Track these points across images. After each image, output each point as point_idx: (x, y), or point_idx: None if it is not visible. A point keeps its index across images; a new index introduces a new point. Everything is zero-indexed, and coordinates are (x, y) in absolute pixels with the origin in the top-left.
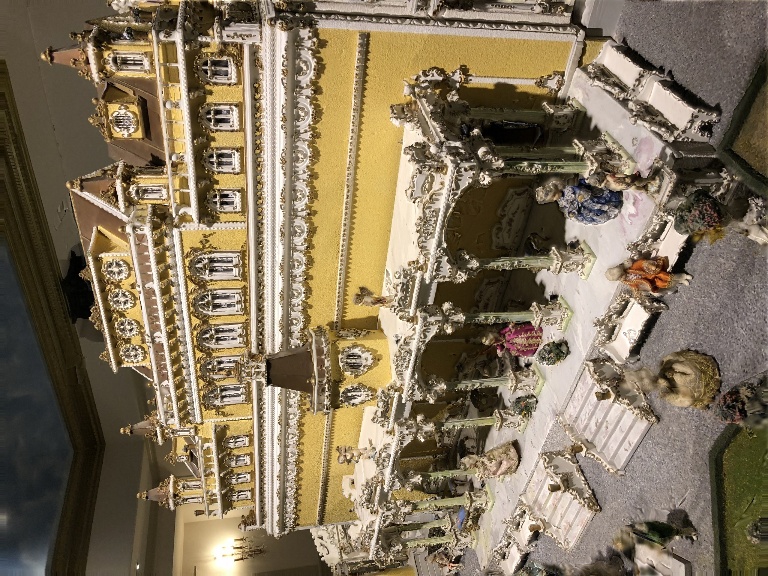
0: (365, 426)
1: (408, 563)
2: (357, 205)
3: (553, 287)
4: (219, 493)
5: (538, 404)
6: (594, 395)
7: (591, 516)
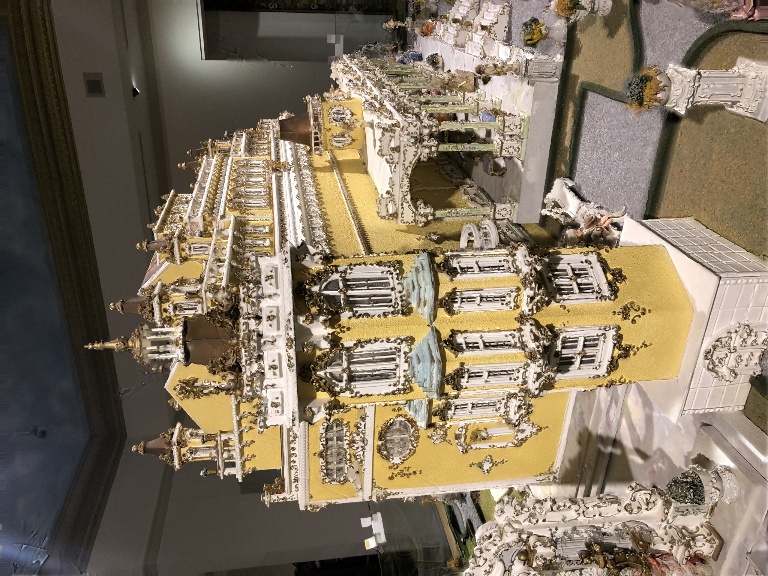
0: (374, 170)
1: None
2: None
3: None
4: (227, 261)
5: None
6: (451, 30)
7: None
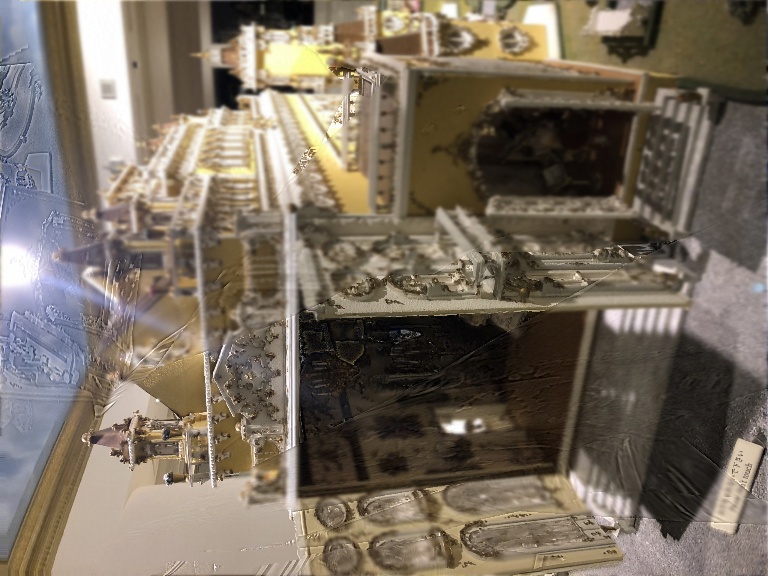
0: None
1: None
2: None
3: None
4: None
5: None
6: None
7: None
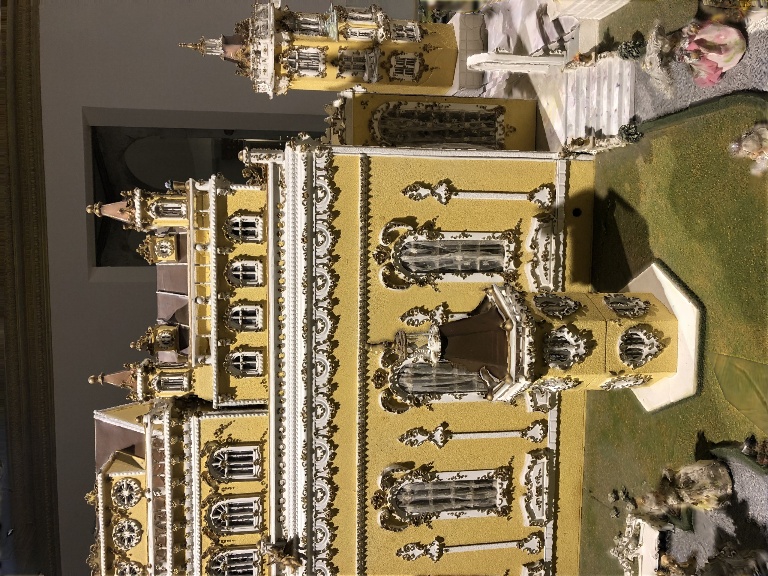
0: None
1: (457, 62)
2: None
3: None
4: None
5: None
6: None
7: None
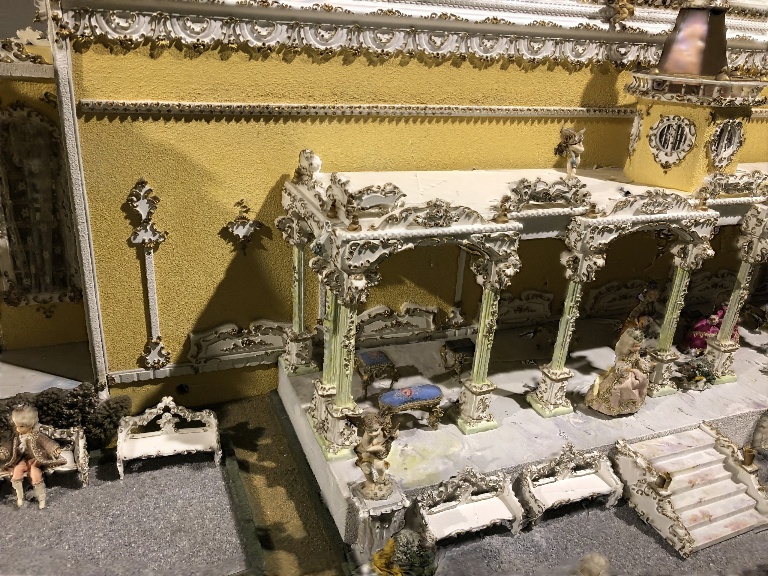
0: None
1: None
2: (767, 123)
3: (764, 343)
4: None
5: (712, 389)
6: None
7: (761, 527)
